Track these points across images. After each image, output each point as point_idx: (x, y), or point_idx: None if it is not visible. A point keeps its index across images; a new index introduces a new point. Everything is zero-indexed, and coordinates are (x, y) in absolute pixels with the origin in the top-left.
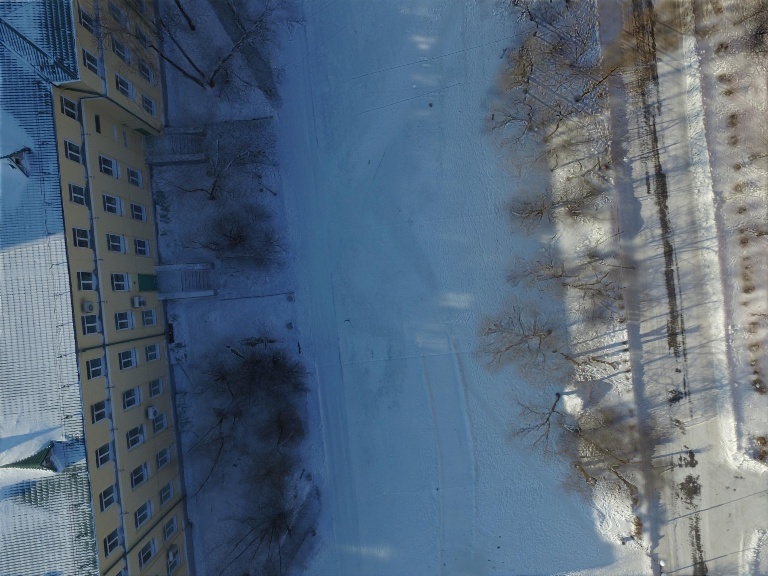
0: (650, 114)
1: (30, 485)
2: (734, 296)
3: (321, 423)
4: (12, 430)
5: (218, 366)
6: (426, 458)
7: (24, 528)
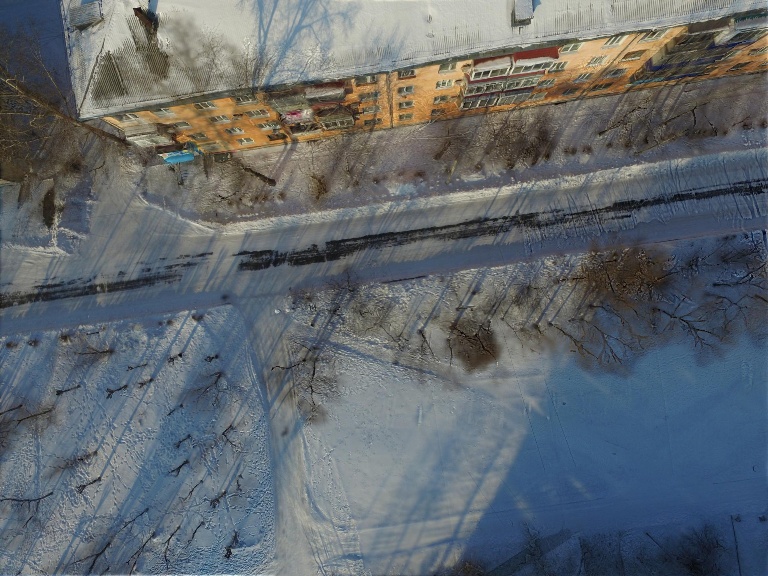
0: (563, 218)
1: None
2: (718, 142)
3: None
4: None
5: None
6: None
7: None
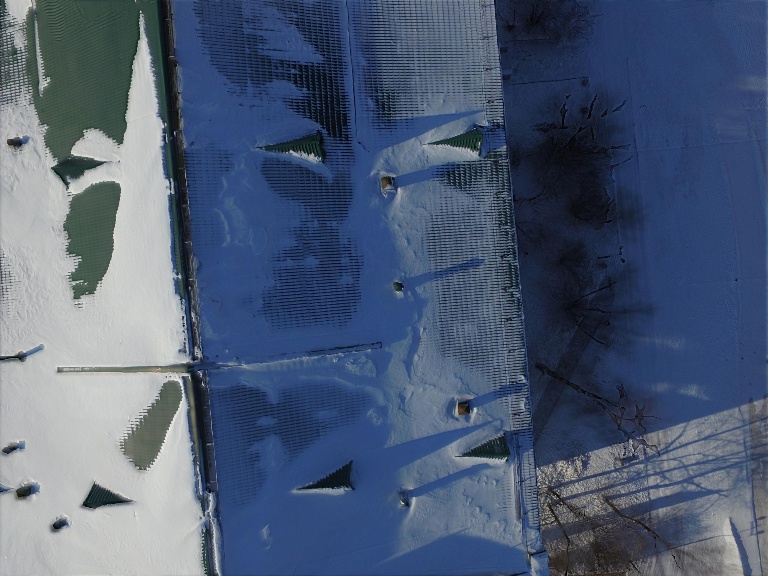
0: None
1: (455, 168)
2: None
3: (616, 211)
4: (439, 109)
5: (512, 150)
6: (724, 248)
7: (450, 211)
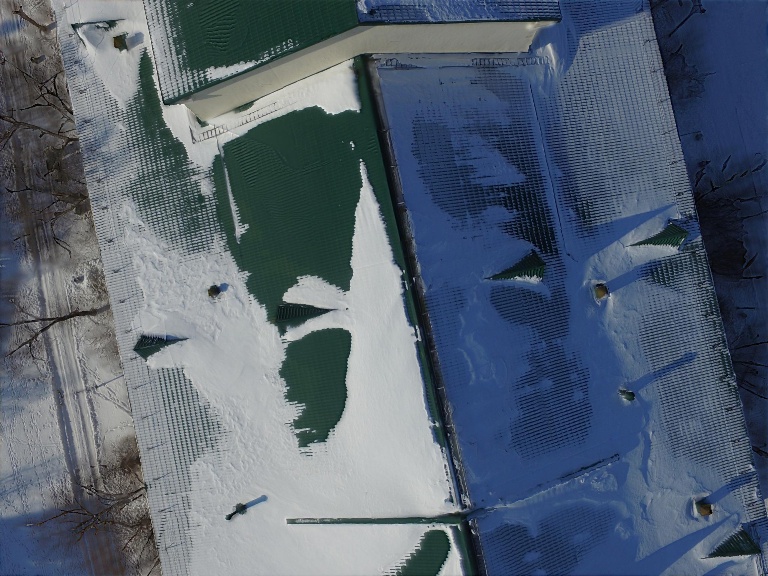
0: None
1: (657, 265)
2: None
3: (746, 259)
4: (634, 209)
5: None
6: None
7: (658, 309)
